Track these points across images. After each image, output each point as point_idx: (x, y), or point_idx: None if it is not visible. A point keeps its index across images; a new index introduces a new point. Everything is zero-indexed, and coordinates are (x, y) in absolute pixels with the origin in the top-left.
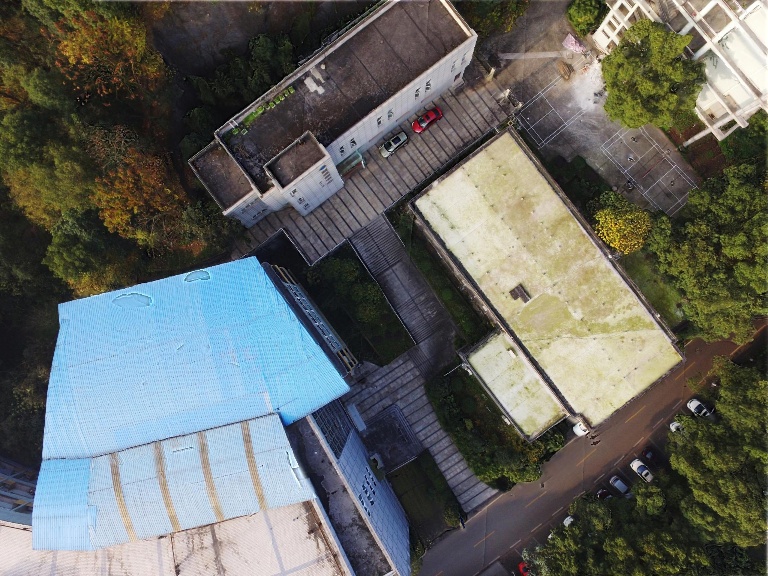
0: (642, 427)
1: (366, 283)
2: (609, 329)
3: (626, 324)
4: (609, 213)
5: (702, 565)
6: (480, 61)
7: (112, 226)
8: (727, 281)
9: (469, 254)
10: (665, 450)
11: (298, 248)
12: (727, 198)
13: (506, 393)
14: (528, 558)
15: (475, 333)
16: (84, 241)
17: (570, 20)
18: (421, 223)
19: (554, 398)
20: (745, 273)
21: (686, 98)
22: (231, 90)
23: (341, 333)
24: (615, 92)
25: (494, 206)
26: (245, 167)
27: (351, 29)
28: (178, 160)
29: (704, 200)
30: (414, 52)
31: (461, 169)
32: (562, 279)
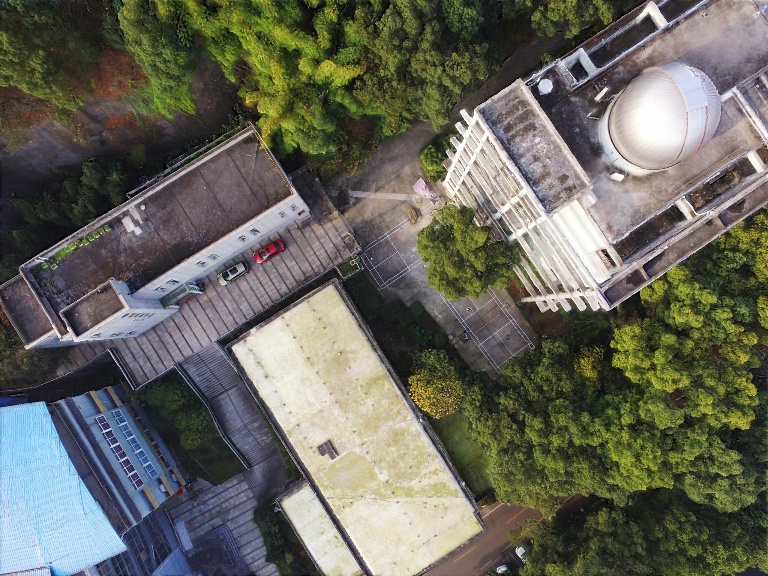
0: (470, 568)
1: (192, 411)
2: (413, 493)
3: (431, 490)
4: (421, 378)
5: None
6: (329, 196)
7: None
8: (526, 462)
9: (281, 405)
10: None
11: (126, 369)
12: (538, 375)
13: (315, 541)
14: None
15: None
16: None
17: (422, 165)
18: None
19: None
20: (539, 459)
21: (496, 280)
22: (54, 215)
23: (177, 448)
24: (432, 263)
25: (310, 359)
26: (51, 303)
27: (171, 175)
28: None
29: (516, 374)
30: (236, 202)
31: (281, 318)
32: (371, 439)
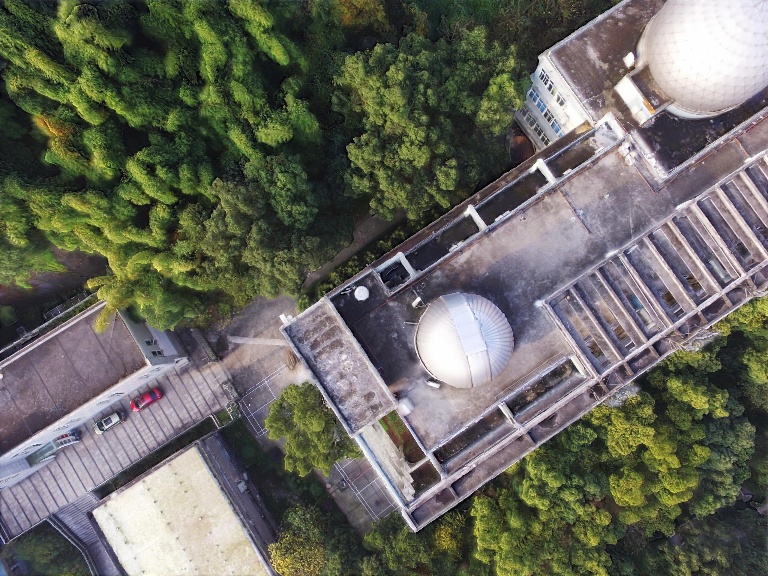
0: None
1: (64, 564)
2: None
3: None
4: (281, 547)
5: None
6: (208, 342)
7: None
8: None
9: (140, 572)
10: None
11: None
12: (399, 543)
13: None
14: None
15: None
16: None
17: None
18: None
19: None
20: None
21: None
22: None
23: None
24: None
25: (171, 524)
26: None
27: (26, 347)
28: None
29: None
30: (94, 370)
31: (142, 482)
32: None
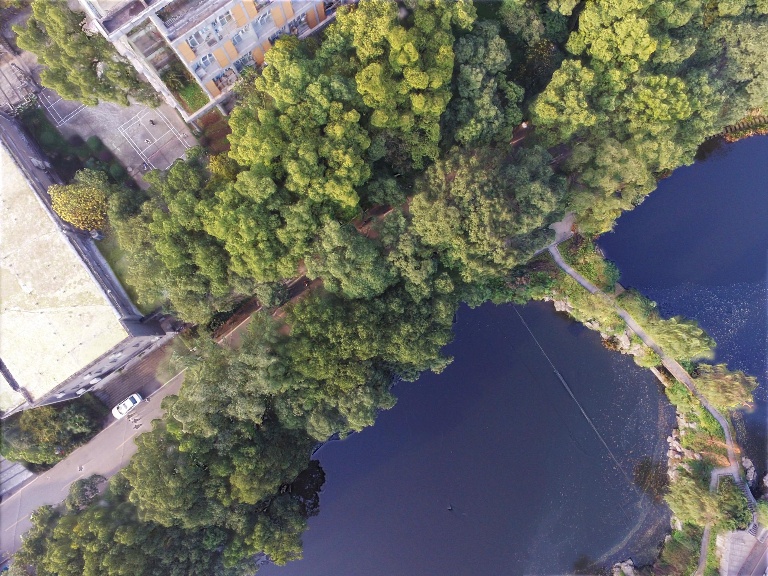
0: None
1: None
2: (57, 303)
3: (76, 299)
4: (58, 187)
5: (126, 544)
6: (5, 38)
7: None
8: (153, 257)
9: None
10: None
11: None
12: None
13: None
14: (23, 540)
15: None
16: None
17: None
18: None
19: None
20: (156, 249)
21: None
22: None
23: None
24: None
25: None
26: None
27: None
28: None
29: (153, 178)
30: None
31: None
32: (15, 252)
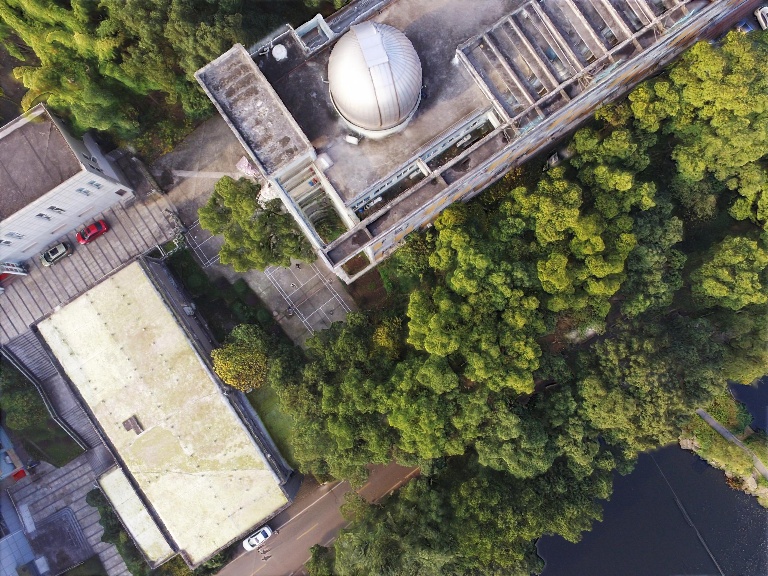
0: None
1: (17, 392)
2: (218, 467)
3: (236, 462)
4: (223, 352)
5: None
6: (153, 176)
7: None
8: (321, 432)
9: (86, 381)
10: None
11: None
12: (337, 346)
13: (134, 517)
14: None
15: None
16: None
17: None
18: None
19: None
20: None
21: None
22: None
23: None
24: None
25: (115, 335)
26: None
27: None
28: None
29: (317, 345)
30: (30, 179)
31: (85, 295)
32: (176, 413)
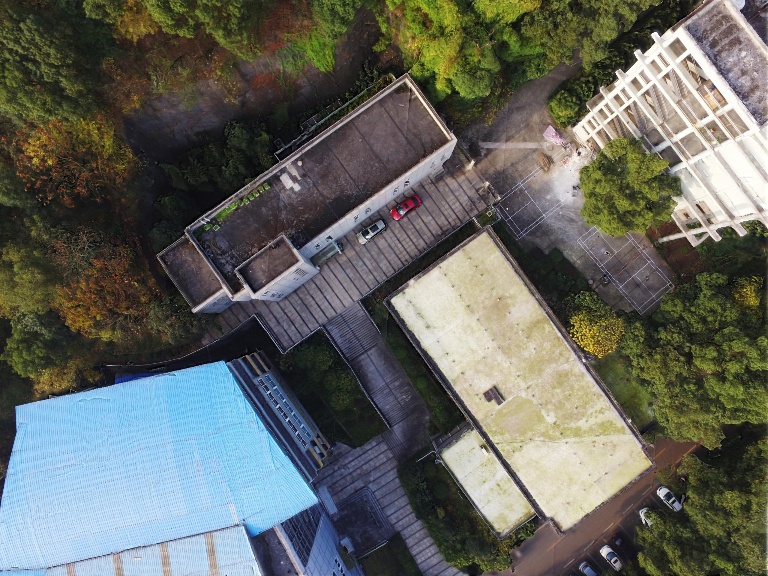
0: (612, 513)
1: (340, 372)
2: (581, 433)
3: (598, 428)
4: (584, 318)
5: None
6: (461, 149)
7: (73, 328)
8: (697, 392)
9: (444, 354)
10: (634, 542)
11: (271, 334)
12: (699, 307)
13: (478, 490)
14: None
15: (449, 422)
16: (44, 339)
17: (551, 112)
18: (396, 321)
19: (525, 499)
20: (714, 387)
21: (662, 212)
22: (204, 179)
23: (314, 413)
24: (592, 201)
25: (470, 306)
26: (216, 264)
27: (329, 128)
28: (148, 244)
29: (677, 308)
30: (393, 152)
31: (438, 268)
32: (536, 382)
